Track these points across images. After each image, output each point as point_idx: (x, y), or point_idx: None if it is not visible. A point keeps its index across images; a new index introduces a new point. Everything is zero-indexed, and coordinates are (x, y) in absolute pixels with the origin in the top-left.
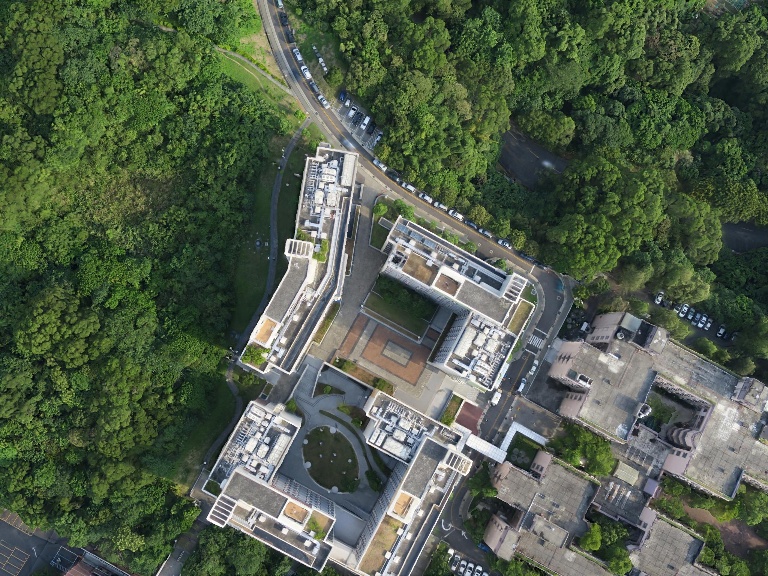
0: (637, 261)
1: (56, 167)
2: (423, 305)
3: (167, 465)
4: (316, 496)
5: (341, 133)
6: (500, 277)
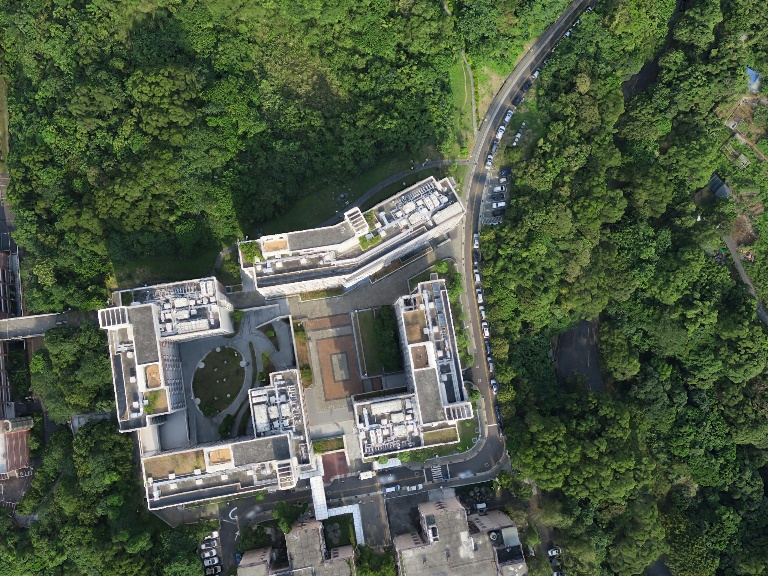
0: (567, 506)
1: (282, 8)
2: (392, 356)
3: (122, 256)
4: (181, 388)
5: (476, 193)
6: (460, 395)
